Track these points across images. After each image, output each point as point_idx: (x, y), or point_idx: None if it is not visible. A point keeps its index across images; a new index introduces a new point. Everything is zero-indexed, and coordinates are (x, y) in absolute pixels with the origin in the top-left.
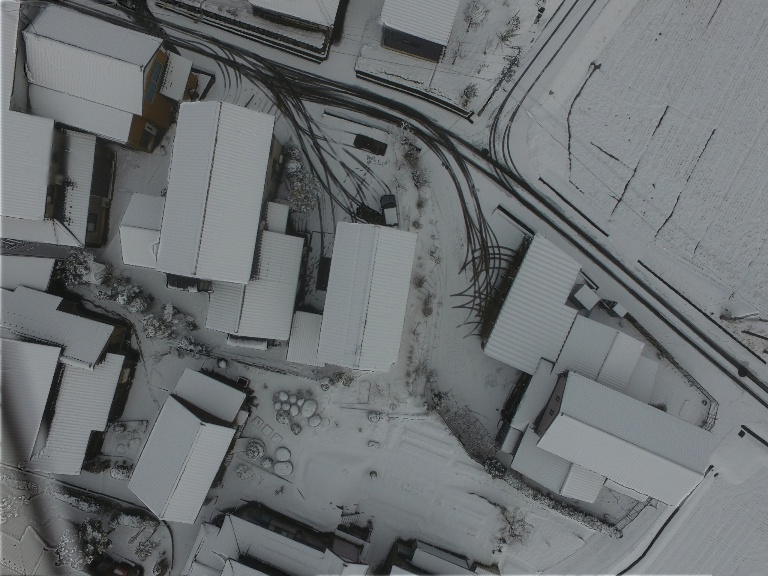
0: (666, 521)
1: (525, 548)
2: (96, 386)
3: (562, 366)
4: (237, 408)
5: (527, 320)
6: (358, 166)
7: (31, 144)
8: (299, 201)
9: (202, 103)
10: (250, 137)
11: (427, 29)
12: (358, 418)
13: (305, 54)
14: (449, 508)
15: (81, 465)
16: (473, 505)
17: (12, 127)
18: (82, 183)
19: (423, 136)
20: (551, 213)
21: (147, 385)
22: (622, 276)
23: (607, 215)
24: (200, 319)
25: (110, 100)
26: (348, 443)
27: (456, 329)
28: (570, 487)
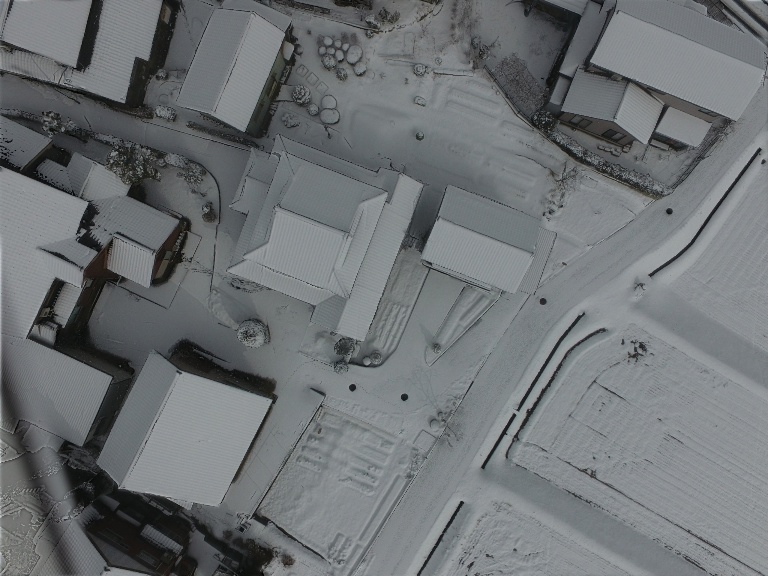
0: (714, 208)
1: (574, 221)
2: (139, 8)
3: (611, 2)
4: (284, 28)
5: None
6: None
7: None
8: None
9: None
10: None
11: None
12: (403, 72)
13: None
14: (498, 169)
15: (126, 93)
16: (522, 166)
17: None
18: None
19: None
20: None
21: (188, 35)
22: None
23: None
24: None
25: None
26: (394, 98)
27: None
28: (624, 116)
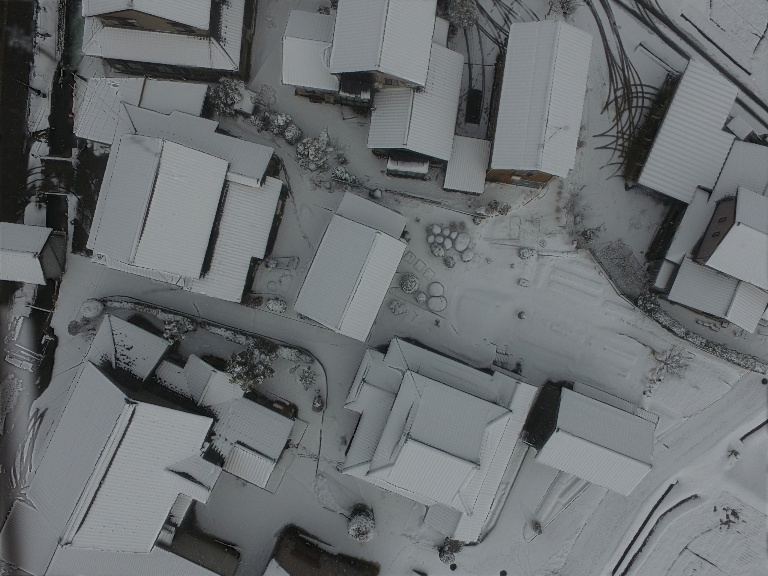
0: None
1: (671, 394)
2: (257, 210)
3: (720, 193)
4: (400, 230)
5: (683, 147)
6: None
7: None
8: (461, 14)
9: None
10: None
11: None
12: (508, 255)
13: None
14: (599, 348)
15: (242, 292)
16: (623, 345)
17: None
18: (236, 3)
19: None
20: (693, 51)
21: (297, 221)
22: (765, 116)
23: (749, 53)
24: (349, 153)
25: None
26: (498, 281)
27: (599, 171)
28: (734, 312)
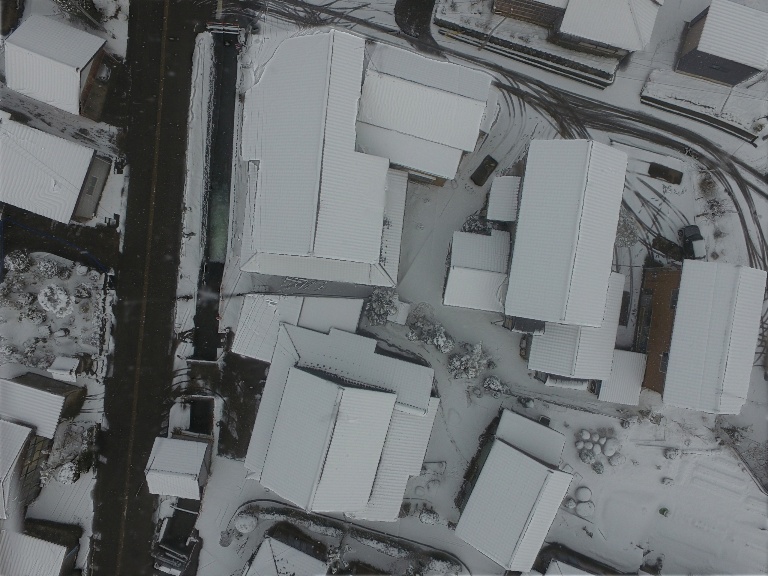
0: None
1: None
2: (416, 431)
3: None
4: (560, 451)
5: None
6: (654, 196)
7: (372, 185)
8: (625, 237)
9: (563, 141)
10: (611, 175)
11: (752, 55)
12: (653, 455)
13: (590, 80)
14: (741, 545)
15: (399, 511)
16: (765, 541)
17: (357, 169)
18: (396, 221)
19: (707, 162)
20: None
21: (444, 425)
22: None
23: None
24: None
25: (437, 136)
26: (643, 481)
27: None
28: None
